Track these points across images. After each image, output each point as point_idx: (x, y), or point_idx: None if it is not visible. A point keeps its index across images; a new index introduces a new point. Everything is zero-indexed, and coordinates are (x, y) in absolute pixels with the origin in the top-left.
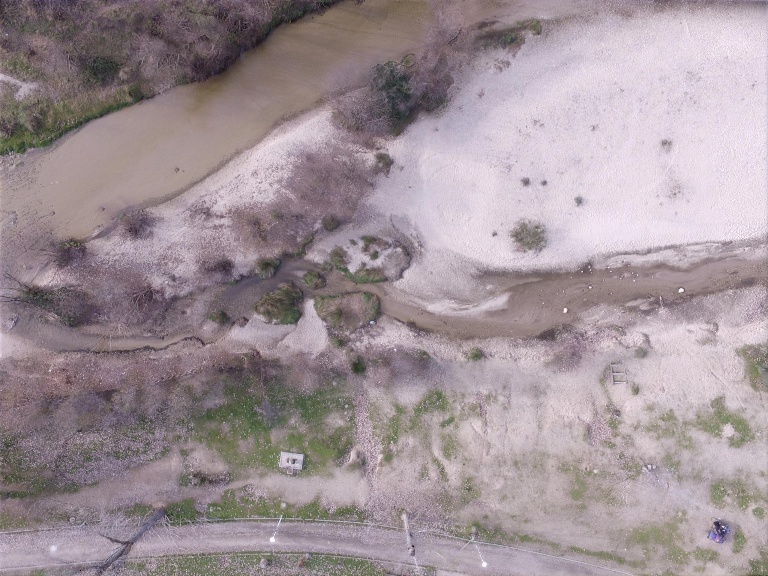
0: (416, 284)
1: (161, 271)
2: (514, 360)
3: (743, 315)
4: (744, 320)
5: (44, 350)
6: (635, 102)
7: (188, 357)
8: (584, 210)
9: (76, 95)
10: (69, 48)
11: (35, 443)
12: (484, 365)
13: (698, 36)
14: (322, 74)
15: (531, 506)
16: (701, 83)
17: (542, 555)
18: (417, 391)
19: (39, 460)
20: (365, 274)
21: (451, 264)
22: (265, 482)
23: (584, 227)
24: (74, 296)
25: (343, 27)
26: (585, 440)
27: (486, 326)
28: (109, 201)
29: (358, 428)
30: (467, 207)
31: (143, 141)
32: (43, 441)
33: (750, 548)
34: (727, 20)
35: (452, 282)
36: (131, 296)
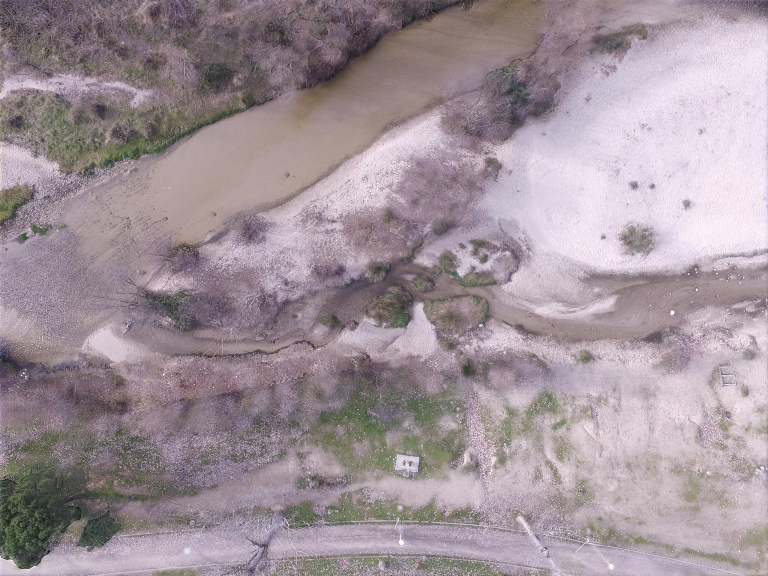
0: (524, 287)
1: (274, 275)
2: (623, 362)
3: None
4: None
5: (157, 354)
6: (742, 105)
7: (299, 361)
8: (691, 213)
9: (190, 102)
10: (184, 55)
11: (152, 446)
12: (593, 367)
13: None
14: (430, 79)
15: (645, 508)
16: None
17: (656, 557)
18: (528, 394)
19: (157, 463)
20: (475, 277)
21: (559, 267)
22: (381, 485)
23: (691, 230)
24: (192, 301)
25: (451, 33)
26: (697, 442)
27: (593, 329)
28: (221, 206)
29: (470, 431)
30: (575, 210)
31: (254, 147)
32: (160, 444)
33: None
34: None
35: (560, 285)
36: (244, 300)
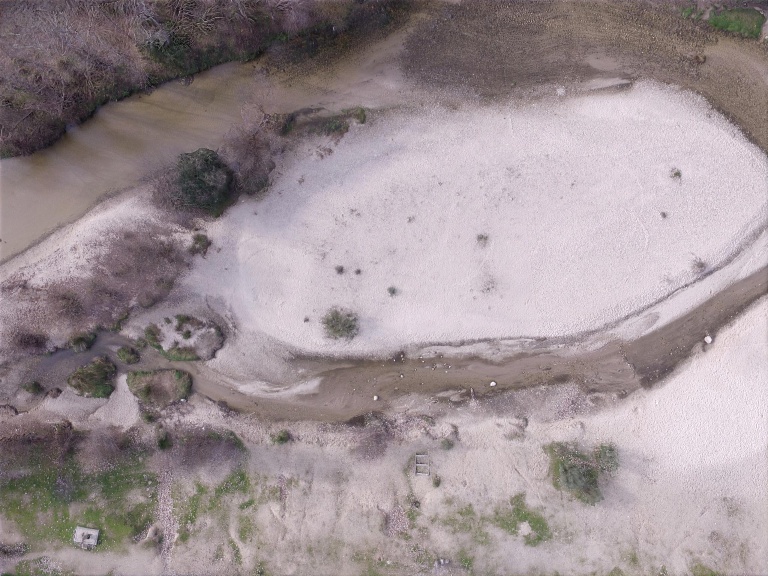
0: (228, 364)
1: None
2: (320, 445)
3: (554, 412)
4: (554, 417)
5: None
6: (453, 196)
7: (0, 425)
8: (397, 300)
9: None
10: None
11: None
12: (290, 449)
13: (520, 132)
14: (146, 153)
15: None
16: (520, 180)
17: None
18: (220, 471)
19: None
20: (177, 353)
21: (264, 346)
22: (60, 555)
23: (397, 317)
24: None
25: (169, 108)
26: (381, 530)
27: (296, 409)
28: None
29: (160, 505)
30: (281, 292)
31: None
32: None
33: None
34: (551, 117)
35: (264, 364)
36: None
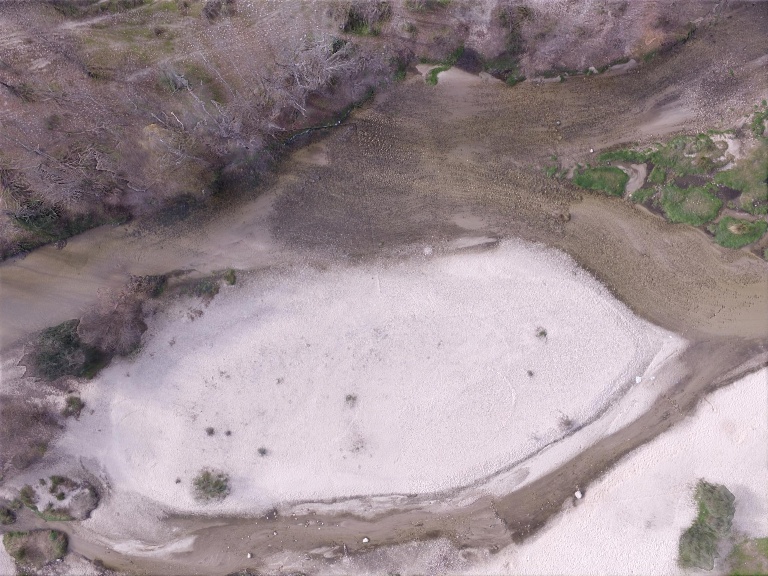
0: (103, 524)
1: None
2: None
3: (426, 568)
4: (427, 573)
5: None
6: (321, 357)
7: None
8: (268, 460)
9: None
10: None
11: None
12: None
13: (388, 293)
14: (21, 316)
15: None
16: (387, 341)
17: None
18: None
19: None
20: (51, 514)
21: (138, 506)
22: None
23: (268, 476)
24: None
25: (42, 271)
26: None
27: (172, 567)
28: None
29: None
30: (153, 453)
31: None
32: None
33: None
34: (419, 277)
35: (139, 523)
36: None
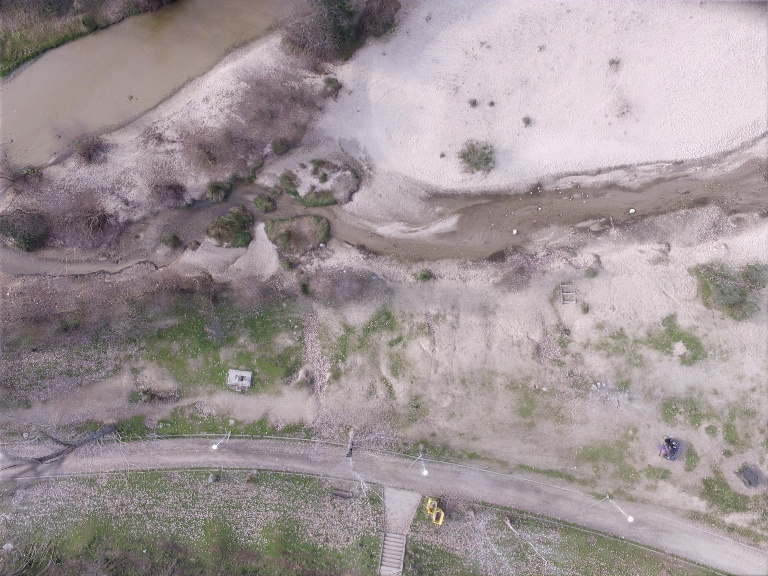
0: (365, 207)
1: (114, 195)
2: (463, 281)
3: (696, 235)
4: (697, 240)
5: (2, 274)
6: (581, 22)
7: (141, 280)
8: (532, 131)
9: (32, 25)
10: None
11: None
12: (433, 286)
13: None
14: (271, 2)
15: (479, 424)
16: (648, 2)
17: (491, 473)
18: (366, 311)
19: None
20: (314, 197)
21: (400, 187)
22: (214, 399)
23: (532, 148)
24: (29, 217)
25: None
26: (534, 358)
27: (436, 248)
28: (65, 129)
29: (307, 348)
30: (415, 129)
31: (98, 70)
32: None
33: (703, 467)
34: None
35: (401, 204)
36: (85, 220)
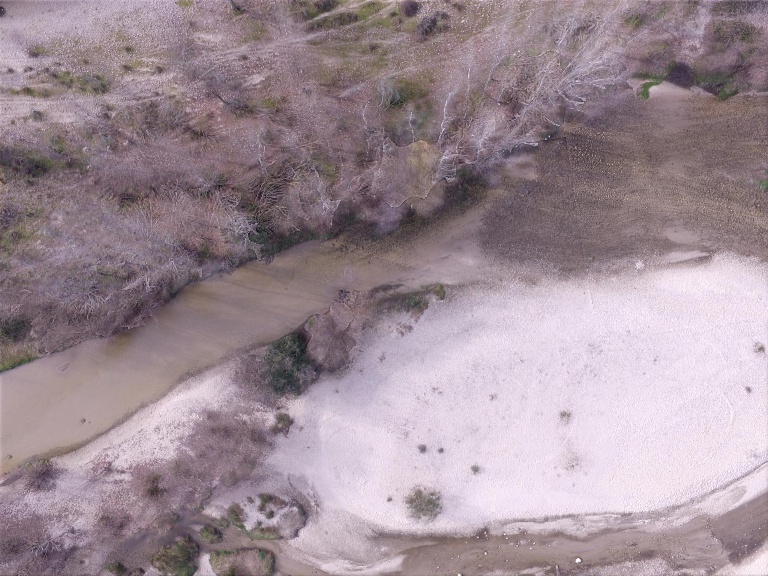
0: (311, 543)
1: (61, 523)
2: None
3: None
4: None
5: None
6: (534, 373)
7: None
8: (481, 478)
9: None
10: None
11: None
12: None
13: (601, 308)
14: (228, 331)
15: None
16: (602, 356)
17: None
18: None
19: None
20: (260, 533)
21: (346, 525)
22: None
23: (480, 495)
24: None
25: (250, 287)
26: None
27: None
28: (17, 449)
29: None
30: (363, 470)
31: (52, 392)
32: None
33: None
34: (631, 292)
35: (347, 543)
36: (31, 547)
